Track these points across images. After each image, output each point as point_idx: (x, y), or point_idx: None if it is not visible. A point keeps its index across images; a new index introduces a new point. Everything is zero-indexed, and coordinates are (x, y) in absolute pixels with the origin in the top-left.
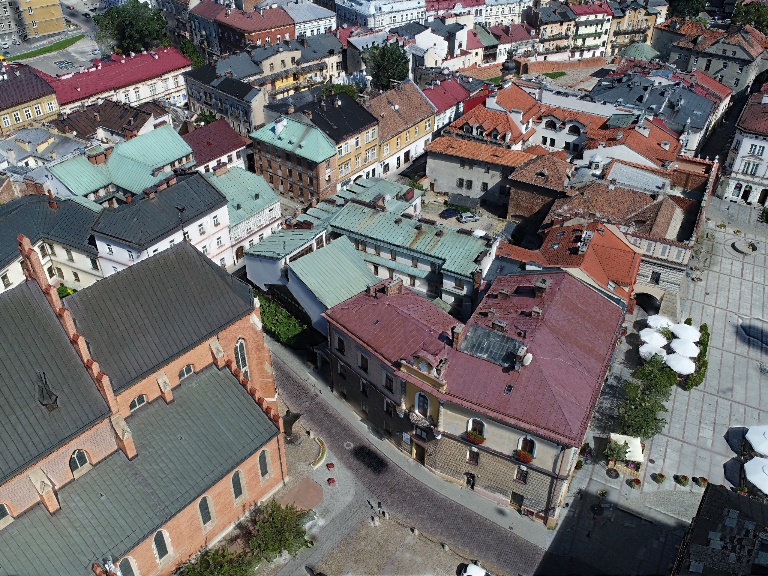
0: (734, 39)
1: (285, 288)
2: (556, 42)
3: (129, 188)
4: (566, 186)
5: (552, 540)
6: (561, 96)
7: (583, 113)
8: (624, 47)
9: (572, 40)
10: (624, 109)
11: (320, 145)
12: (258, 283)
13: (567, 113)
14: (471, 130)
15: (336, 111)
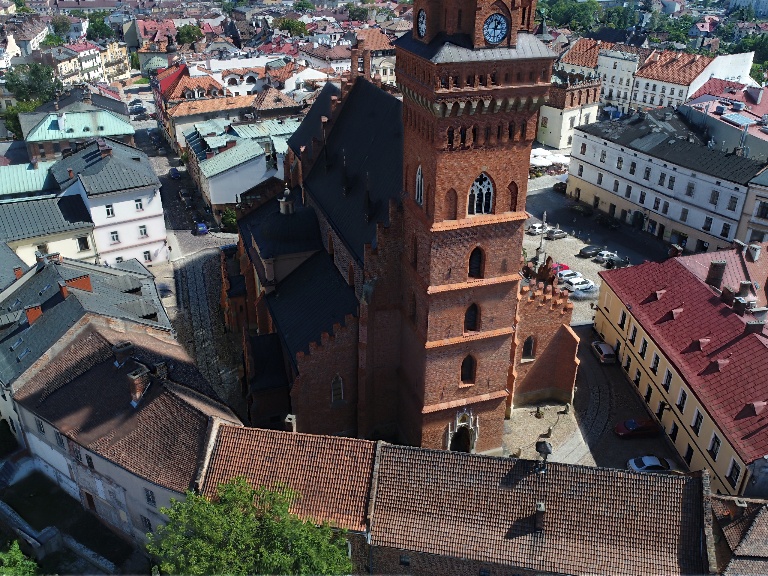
0: (220, 39)
1: (264, 186)
2: (71, 78)
3: (10, 191)
4: (298, 102)
5: (529, 213)
6: (225, 60)
7: (247, 68)
8: (115, 77)
9: (81, 75)
10: (273, 57)
11: (119, 122)
12: (230, 200)
13: (236, 71)
14: (193, 95)
15: (94, 100)
